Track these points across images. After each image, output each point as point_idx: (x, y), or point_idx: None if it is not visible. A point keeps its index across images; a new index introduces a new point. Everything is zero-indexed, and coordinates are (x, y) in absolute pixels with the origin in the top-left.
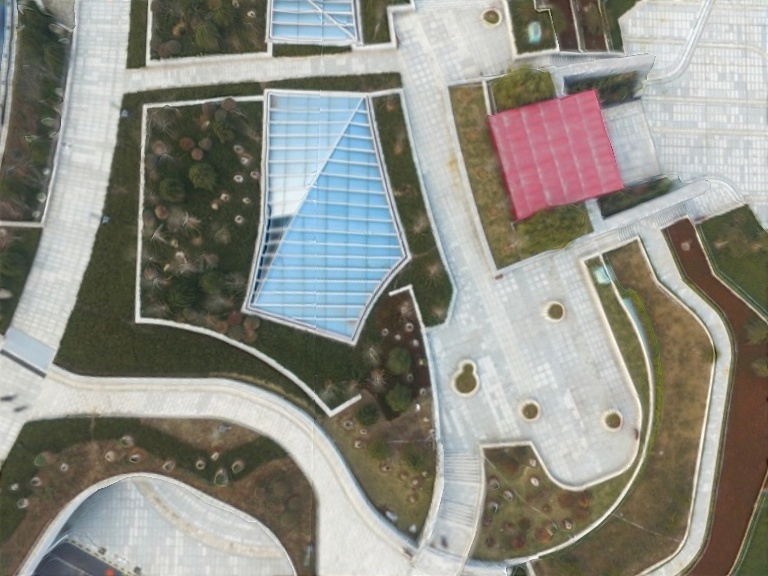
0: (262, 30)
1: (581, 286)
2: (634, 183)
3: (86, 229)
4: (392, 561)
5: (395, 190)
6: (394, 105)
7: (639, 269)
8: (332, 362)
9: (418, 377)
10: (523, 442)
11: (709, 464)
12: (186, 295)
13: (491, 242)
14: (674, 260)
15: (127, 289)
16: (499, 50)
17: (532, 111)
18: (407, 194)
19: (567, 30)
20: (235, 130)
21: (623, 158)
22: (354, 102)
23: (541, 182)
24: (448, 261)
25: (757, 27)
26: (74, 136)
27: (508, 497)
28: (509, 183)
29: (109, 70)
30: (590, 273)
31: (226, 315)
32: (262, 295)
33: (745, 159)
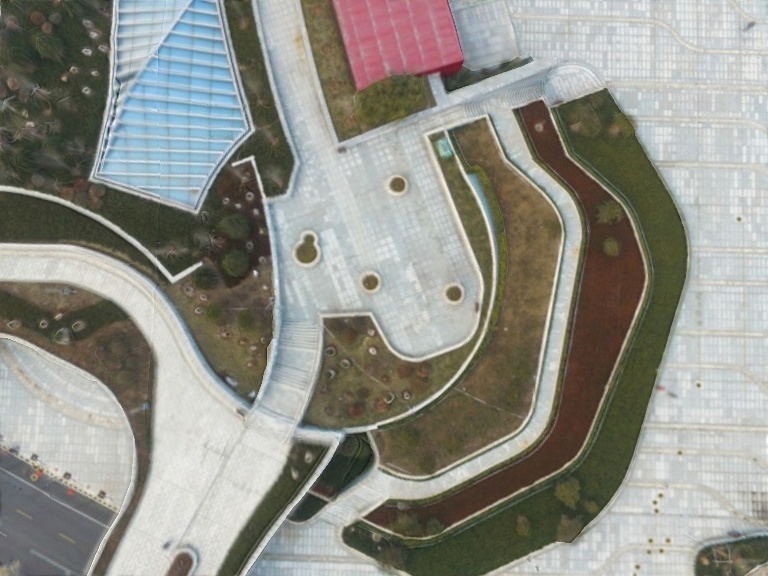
0: None
1: (426, 161)
2: (492, 67)
3: None
4: (226, 422)
5: (240, 65)
6: None
7: (487, 147)
8: (174, 230)
9: (258, 245)
10: (363, 313)
11: (556, 343)
12: (28, 158)
13: (334, 116)
14: (525, 139)
15: None
16: None
17: None
18: (252, 68)
19: None
20: (83, 4)
21: (483, 44)
22: None
23: (381, 54)
24: (292, 135)
25: None
26: None
27: (345, 365)
28: (349, 55)
29: None
30: (433, 147)
31: (73, 182)
32: (107, 163)
33: (608, 45)
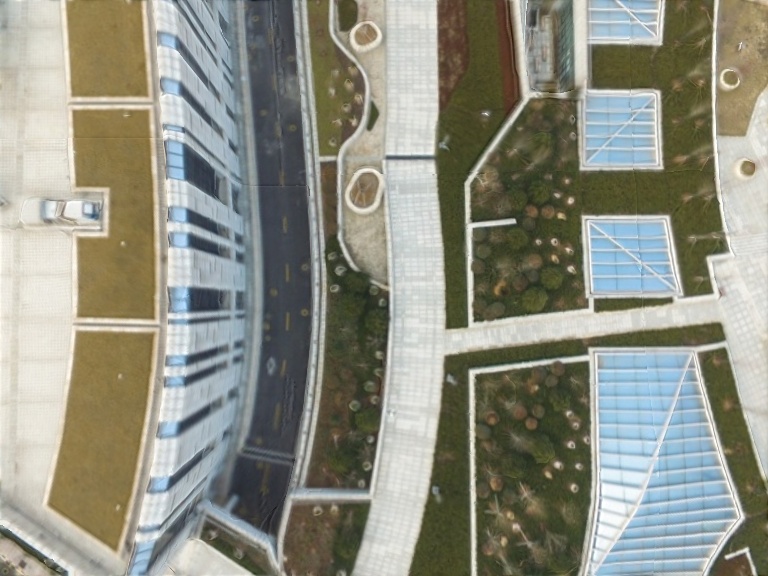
0: (581, 284)
1: None
2: None
3: (414, 499)
4: None
5: (725, 448)
6: (721, 360)
7: None
8: None
9: None
10: None
11: None
12: None
13: None
14: None
15: (461, 562)
16: None
17: None
18: (738, 452)
19: None
20: (570, 399)
21: None
22: (683, 360)
23: None
24: None
25: None
26: (397, 402)
27: None
28: None
29: (428, 331)
30: None
31: None
32: (602, 567)
33: None
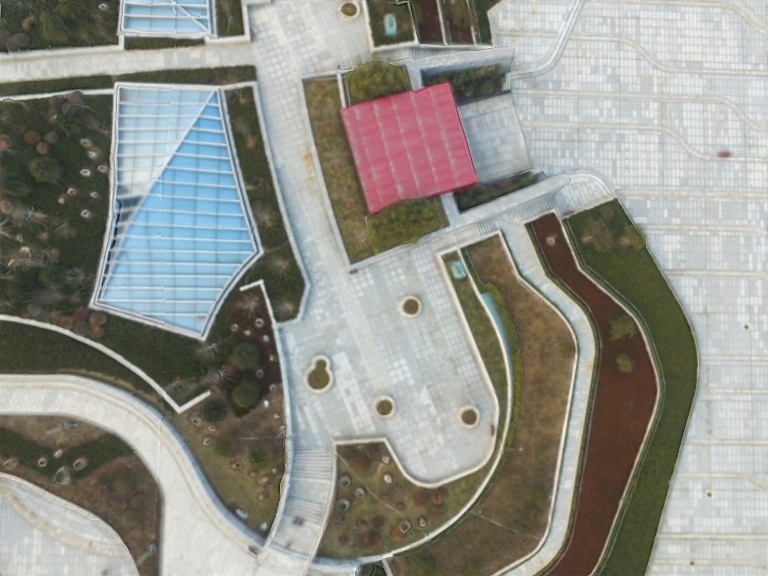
0: (114, 23)
1: (439, 281)
2: (502, 177)
3: None
4: (238, 559)
5: (247, 184)
6: (247, 98)
7: (500, 264)
8: (181, 358)
9: (268, 373)
10: (377, 439)
11: (571, 461)
12: (25, 290)
13: (345, 236)
14: (537, 255)
15: None
16: (357, 43)
17: (384, 104)
18: (259, 188)
19: (431, 23)
20: (80, 123)
21: (493, 152)
22: (205, 95)
23: (393, 176)
24: (302, 256)
25: (631, 20)
26: None
27: (359, 494)
28: (361, 177)
29: None
30: (446, 268)
31: (72, 311)
32: (108, 290)
33: (617, 153)
